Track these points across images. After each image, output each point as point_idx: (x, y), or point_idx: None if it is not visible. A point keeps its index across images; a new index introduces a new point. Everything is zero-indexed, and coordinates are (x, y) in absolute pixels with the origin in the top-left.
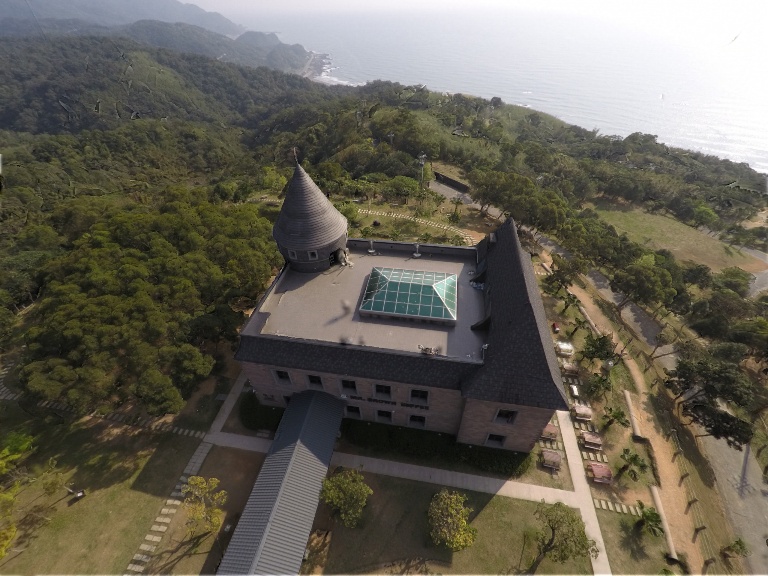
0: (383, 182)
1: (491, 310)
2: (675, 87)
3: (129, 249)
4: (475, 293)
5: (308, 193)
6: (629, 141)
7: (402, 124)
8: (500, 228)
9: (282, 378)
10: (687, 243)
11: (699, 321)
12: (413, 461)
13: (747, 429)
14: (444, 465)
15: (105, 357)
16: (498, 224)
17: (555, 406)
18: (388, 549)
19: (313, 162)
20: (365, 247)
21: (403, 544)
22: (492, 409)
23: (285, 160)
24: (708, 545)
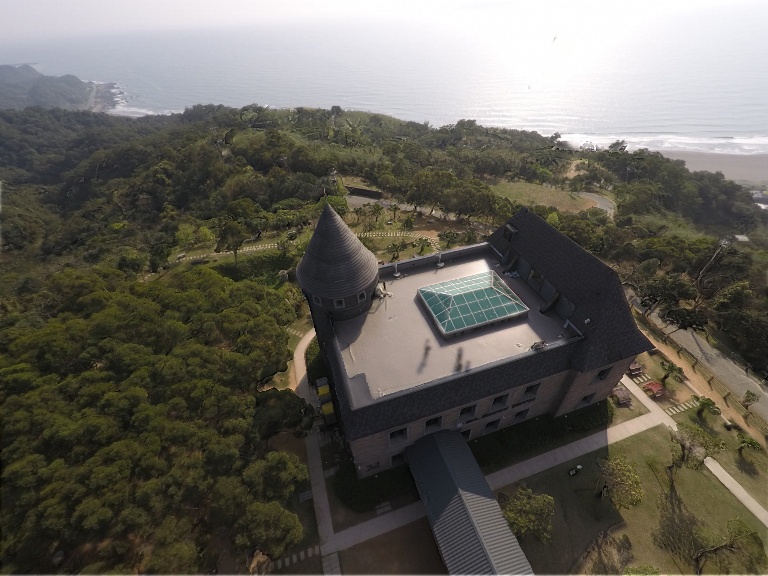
0: (306, 207)
1: (559, 290)
2: (533, 79)
3: (80, 374)
4: (516, 282)
5: (343, 232)
6: (462, 128)
7: (282, 145)
8: (514, 218)
9: (392, 438)
10: (547, 198)
11: (614, 252)
12: (533, 454)
13: (705, 315)
14: (557, 443)
15: (172, 525)
16: (437, 219)
17: (646, 348)
18: (575, 542)
19: (177, 205)
20: (387, 273)
21: (581, 530)
22: (594, 373)
23: (135, 210)
24: (738, 404)
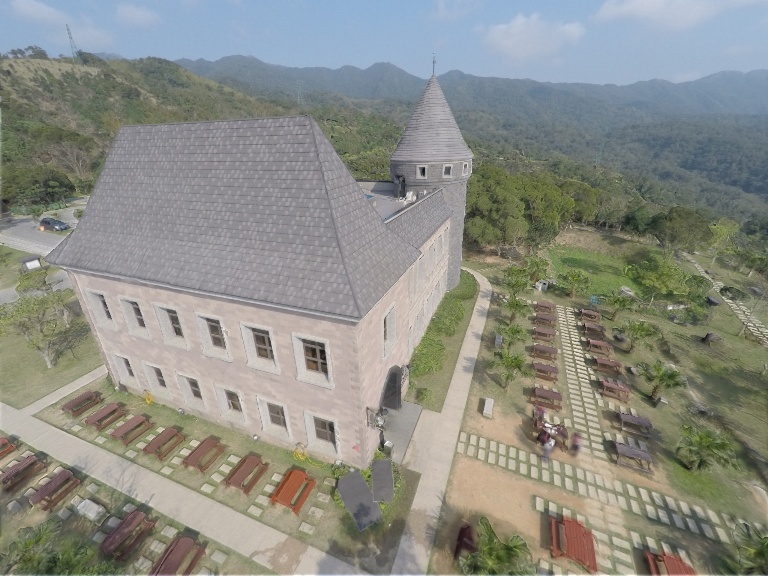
0: None
1: None
2: None
3: None
4: None
5: None
6: None
7: None
8: None
9: None
10: None
11: None
12: None
13: None
14: None
15: None
16: None
17: None
18: None
19: None
20: None
21: None
22: None
23: None
24: None
